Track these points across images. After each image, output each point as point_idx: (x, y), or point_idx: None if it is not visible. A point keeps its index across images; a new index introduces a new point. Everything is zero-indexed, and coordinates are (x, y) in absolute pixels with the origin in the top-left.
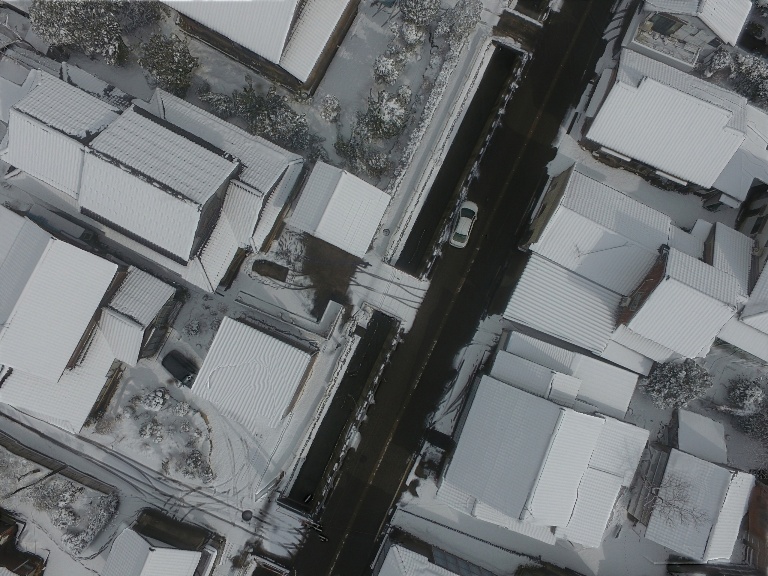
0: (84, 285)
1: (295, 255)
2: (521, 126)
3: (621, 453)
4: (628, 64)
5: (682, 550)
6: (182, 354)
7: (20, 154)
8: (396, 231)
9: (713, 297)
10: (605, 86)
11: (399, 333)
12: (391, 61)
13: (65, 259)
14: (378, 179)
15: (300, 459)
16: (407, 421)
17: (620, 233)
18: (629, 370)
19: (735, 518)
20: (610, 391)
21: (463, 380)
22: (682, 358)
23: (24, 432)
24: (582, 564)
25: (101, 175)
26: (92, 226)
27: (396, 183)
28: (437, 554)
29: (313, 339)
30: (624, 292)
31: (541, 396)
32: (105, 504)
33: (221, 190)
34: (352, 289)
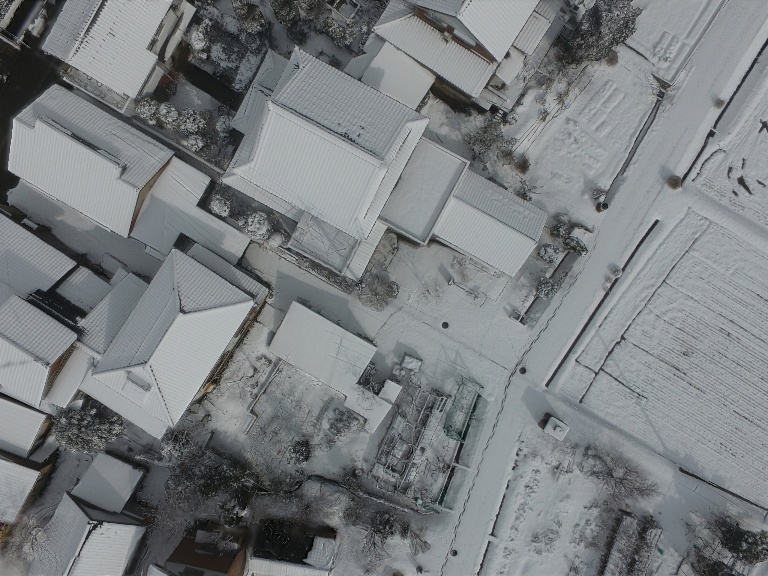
0: None
1: None
2: None
3: (0, 490)
4: (44, 102)
5: None
6: None
7: None
8: None
9: (27, 351)
10: None
11: None
12: None
13: None
14: None
15: None
16: None
17: None
18: (35, 409)
19: (114, 567)
20: (8, 428)
21: None
22: (76, 404)
23: None
24: None
25: None
26: None
27: None
28: None
29: None
30: None
31: None
32: None
33: None
34: None
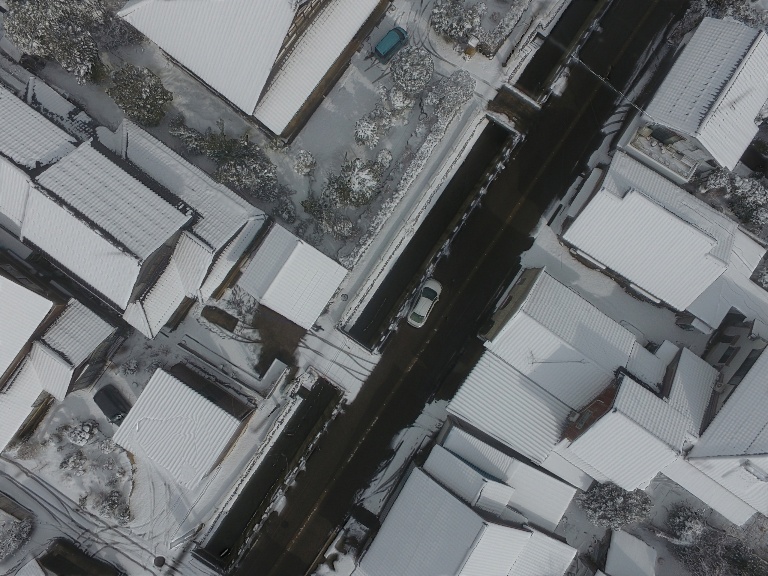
0: (14, 319)
1: (247, 306)
2: (501, 210)
3: (543, 568)
4: (618, 170)
5: None
6: (117, 389)
7: None
8: (354, 298)
9: (659, 438)
10: (592, 186)
11: (341, 403)
12: (372, 127)
13: None
14: (344, 242)
15: (222, 512)
16: (335, 494)
17: (578, 349)
18: (567, 483)
19: None
20: (544, 502)
21: (399, 461)
22: None
23: None
24: None
25: (44, 211)
26: None
27: (360, 252)
28: None
29: (252, 395)
30: (574, 406)
31: (468, 502)
32: (17, 529)
33: (172, 239)
34: (300, 350)
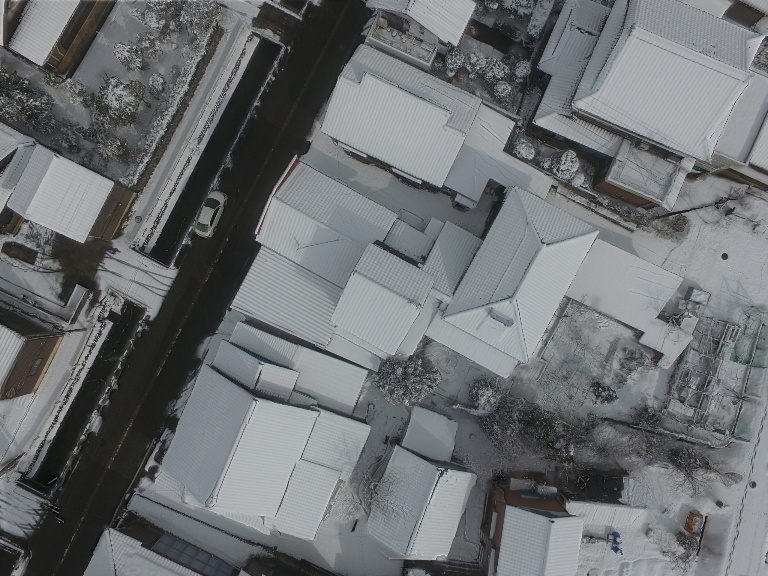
0: None
1: (45, 238)
2: (276, 118)
3: (338, 447)
4: (359, 60)
5: (391, 545)
6: None
7: None
8: (146, 218)
9: (399, 294)
10: None
11: (144, 320)
12: (127, 48)
13: None
14: (128, 166)
15: (45, 441)
16: (148, 407)
17: (332, 227)
18: (358, 365)
19: (452, 516)
20: (336, 385)
21: None
22: (405, 355)
23: None
24: (318, 556)
25: None
26: None
27: (138, 170)
28: (165, 540)
29: (59, 322)
30: None
31: (248, 386)
32: None
33: None
34: (100, 274)
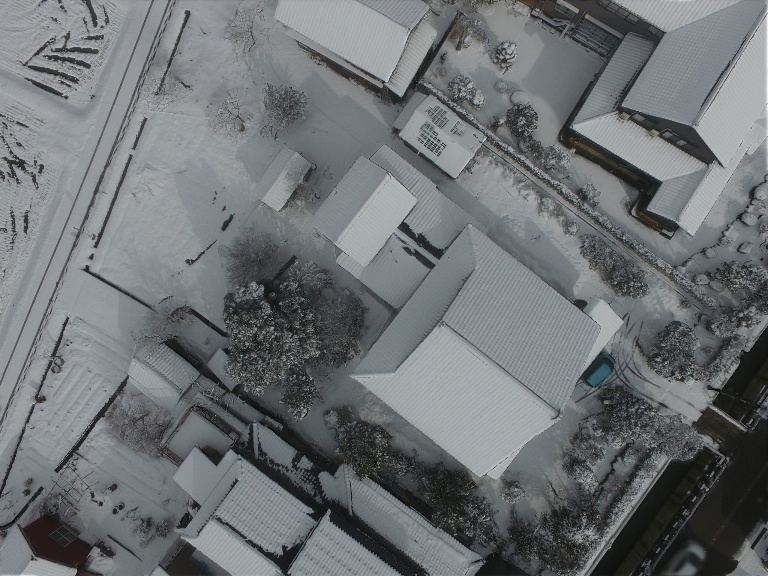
0: None
1: None
2: (704, 532)
3: None
4: None
5: None
6: None
7: (208, 547)
8: None
9: None
10: None
11: None
12: (592, 475)
13: None
14: None
15: None
16: None
17: None
18: None
19: None
20: None
21: None
22: None
23: None
24: None
25: None
26: None
27: None
28: None
29: None
30: None
31: None
32: None
33: None
34: None
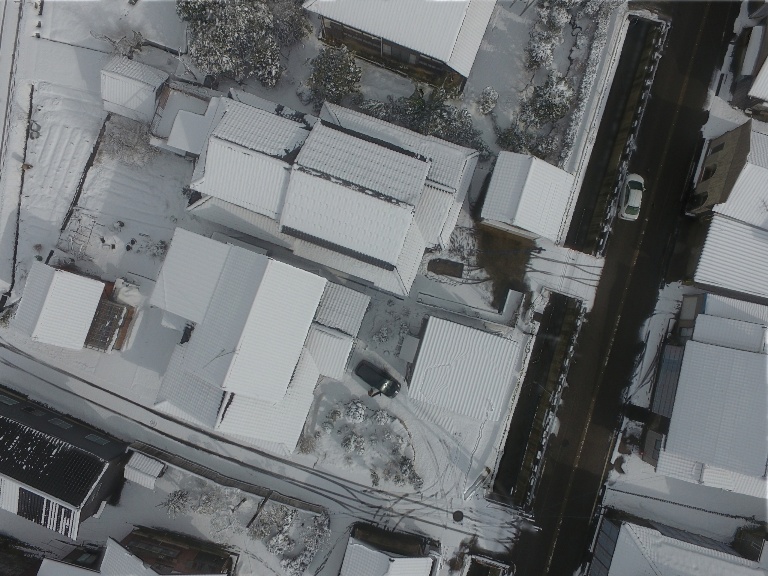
0: (299, 302)
1: (468, 250)
2: (670, 94)
3: None
4: None
5: None
6: (371, 363)
7: (217, 182)
8: None
9: None
10: (758, 43)
11: (583, 313)
12: (549, 46)
13: (282, 278)
14: None
15: (499, 452)
16: (603, 399)
17: None
18: None
19: None
20: None
21: (652, 351)
22: None
23: (224, 463)
24: None
25: (308, 190)
26: (279, 246)
27: (564, 165)
28: (658, 527)
29: (498, 330)
30: None
31: None
32: (319, 524)
33: None
34: (529, 276)
